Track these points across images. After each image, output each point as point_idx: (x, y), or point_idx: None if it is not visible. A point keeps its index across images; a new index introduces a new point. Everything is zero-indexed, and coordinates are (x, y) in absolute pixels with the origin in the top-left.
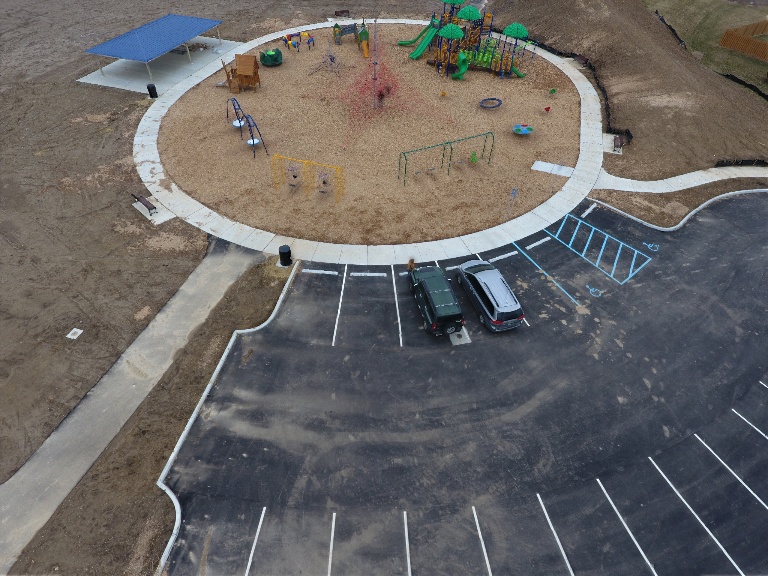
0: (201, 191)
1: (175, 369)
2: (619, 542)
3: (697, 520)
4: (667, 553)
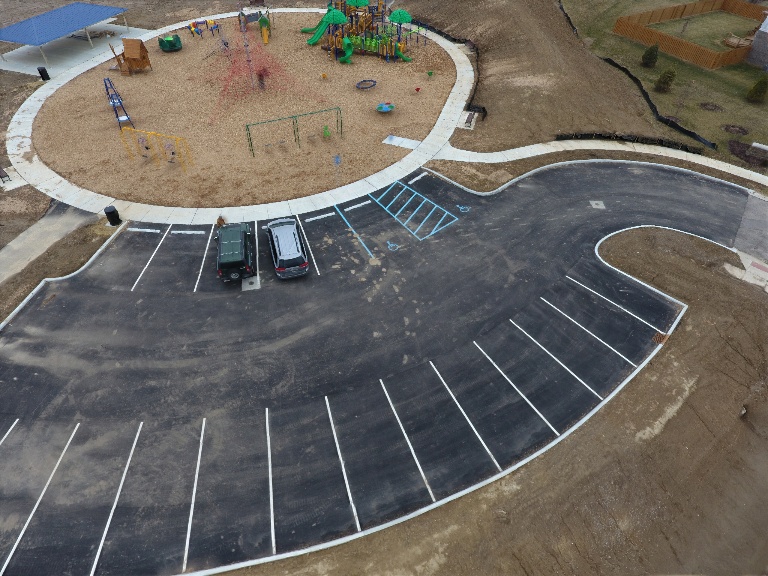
0: (60, 162)
1: None
2: (323, 445)
3: (399, 428)
4: (361, 453)
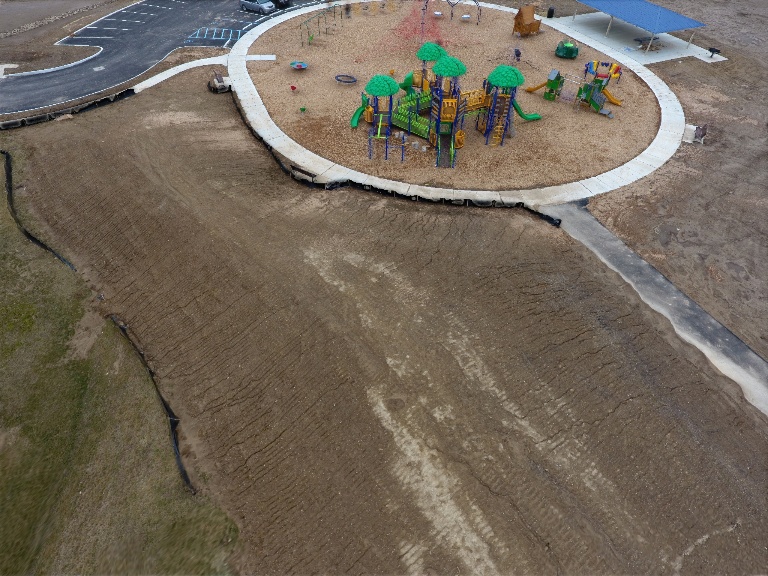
0: None
1: None
2: None
3: (174, 0)
4: None
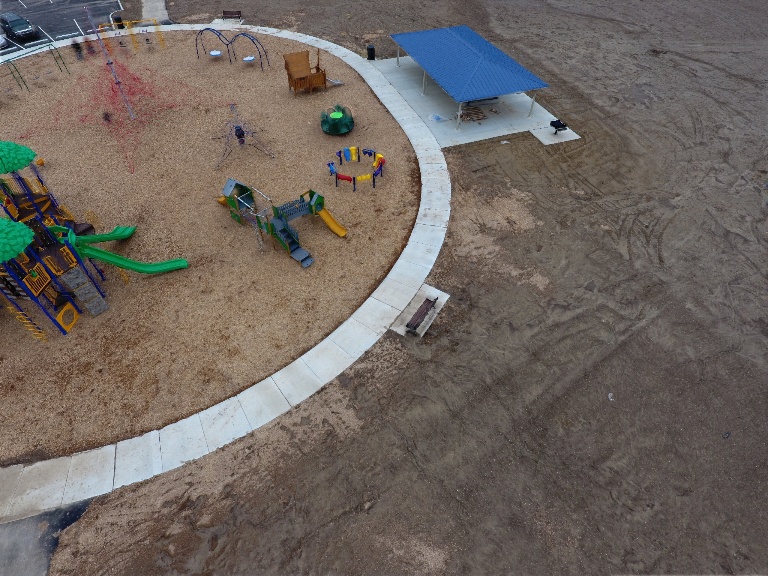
0: None
1: (138, 1)
2: None
3: None
4: None
